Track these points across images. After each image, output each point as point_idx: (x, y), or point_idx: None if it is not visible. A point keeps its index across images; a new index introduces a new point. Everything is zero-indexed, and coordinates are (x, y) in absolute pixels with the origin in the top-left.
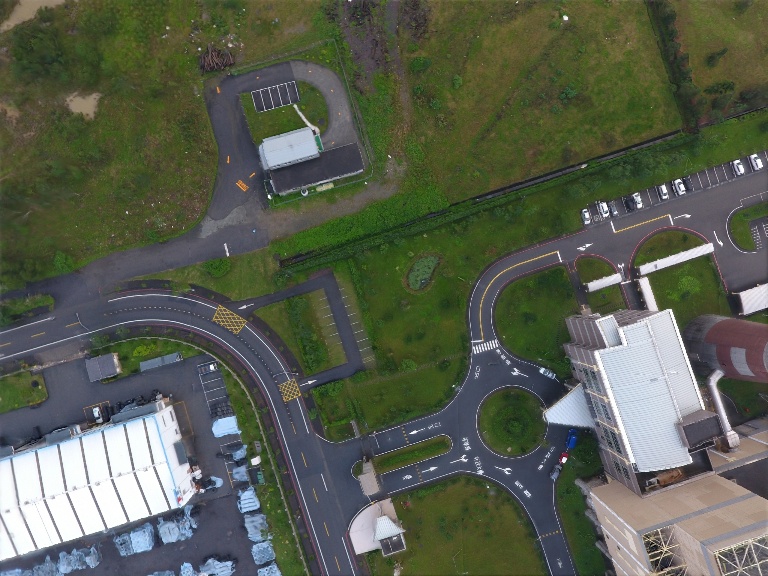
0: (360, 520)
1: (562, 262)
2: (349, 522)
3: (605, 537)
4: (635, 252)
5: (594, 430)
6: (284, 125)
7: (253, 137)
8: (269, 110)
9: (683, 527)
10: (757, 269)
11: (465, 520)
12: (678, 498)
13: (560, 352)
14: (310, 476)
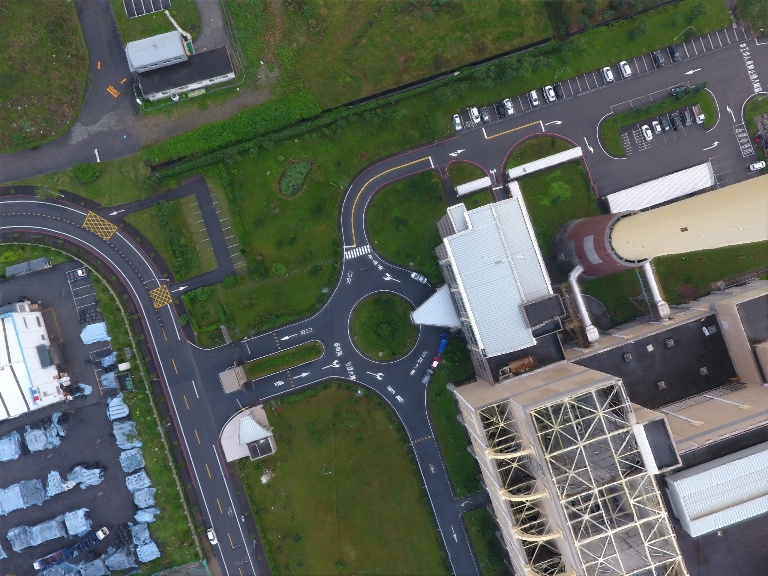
0: (231, 427)
1: (434, 168)
2: (220, 429)
3: (470, 436)
4: (507, 158)
5: (463, 333)
6: (155, 31)
7: (124, 42)
8: (140, 16)
9: (515, 399)
10: (627, 175)
11: (337, 426)
12: (524, 382)
13: (432, 257)
14: (181, 383)
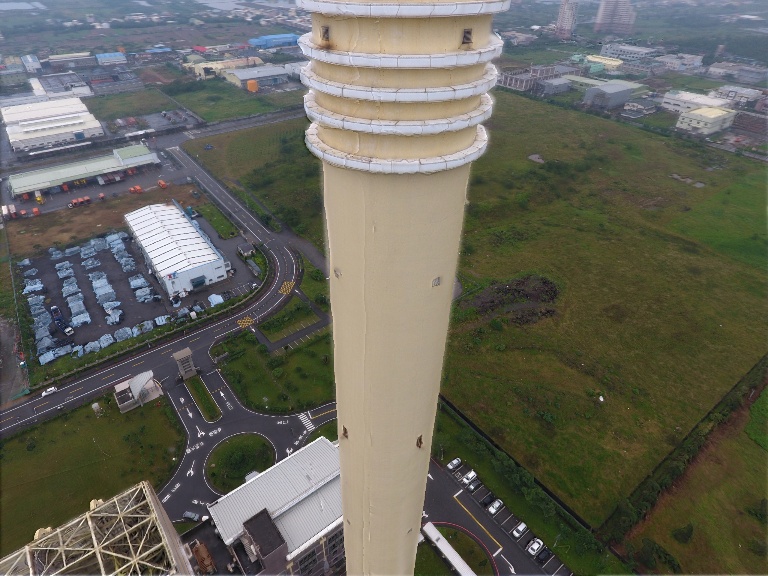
0: None
1: None
2: None
3: None
4: (445, 524)
5: None
6: None
7: None
8: None
9: None
10: None
11: None
12: None
13: None
14: (182, 346)
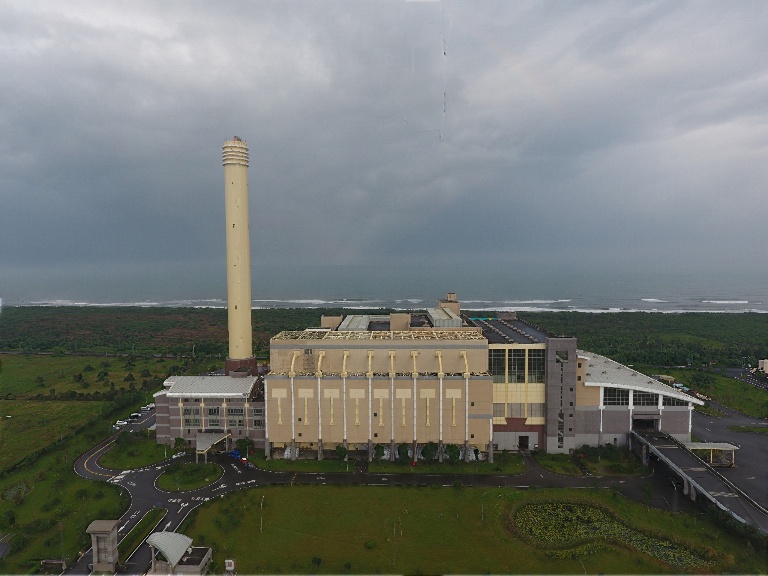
0: None
1: None
2: None
3: (303, 440)
4: None
5: None
6: None
7: None
8: None
9: None
10: None
11: None
12: None
13: None
14: None
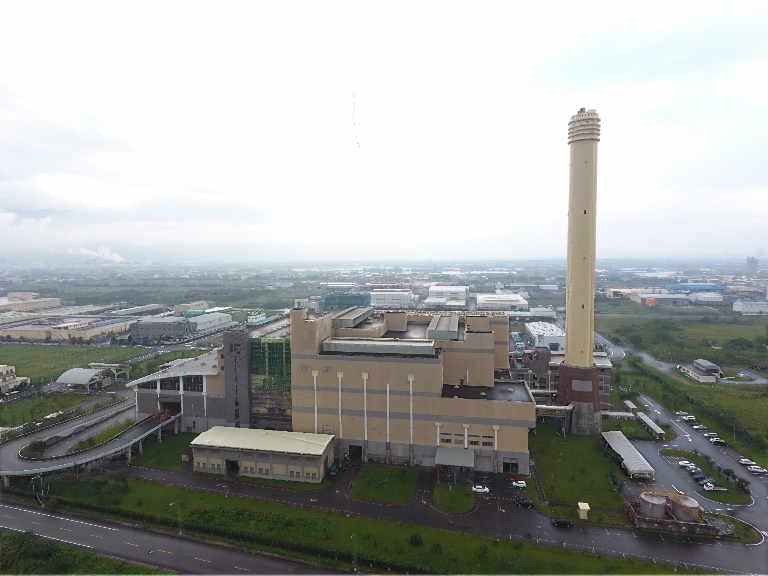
0: None
1: None
2: None
3: None
4: None
5: None
6: None
7: None
8: None
9: None
10: None
11: None
12: None
13: None
14: None
